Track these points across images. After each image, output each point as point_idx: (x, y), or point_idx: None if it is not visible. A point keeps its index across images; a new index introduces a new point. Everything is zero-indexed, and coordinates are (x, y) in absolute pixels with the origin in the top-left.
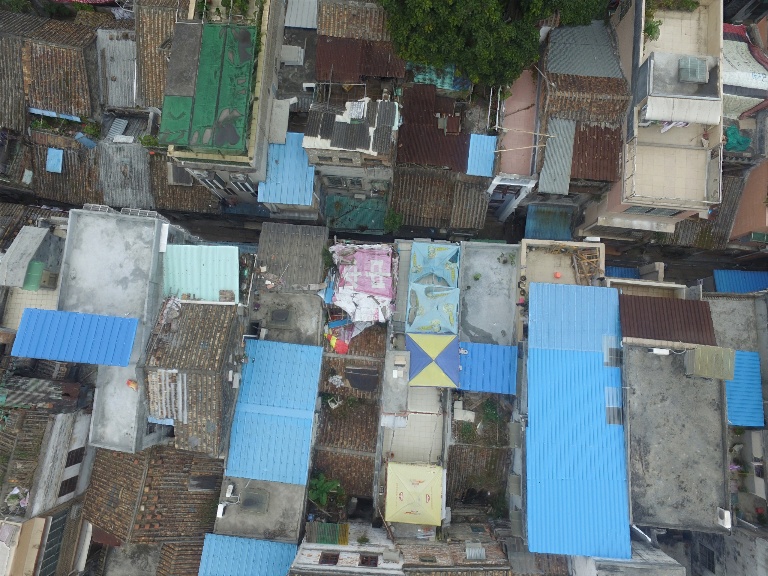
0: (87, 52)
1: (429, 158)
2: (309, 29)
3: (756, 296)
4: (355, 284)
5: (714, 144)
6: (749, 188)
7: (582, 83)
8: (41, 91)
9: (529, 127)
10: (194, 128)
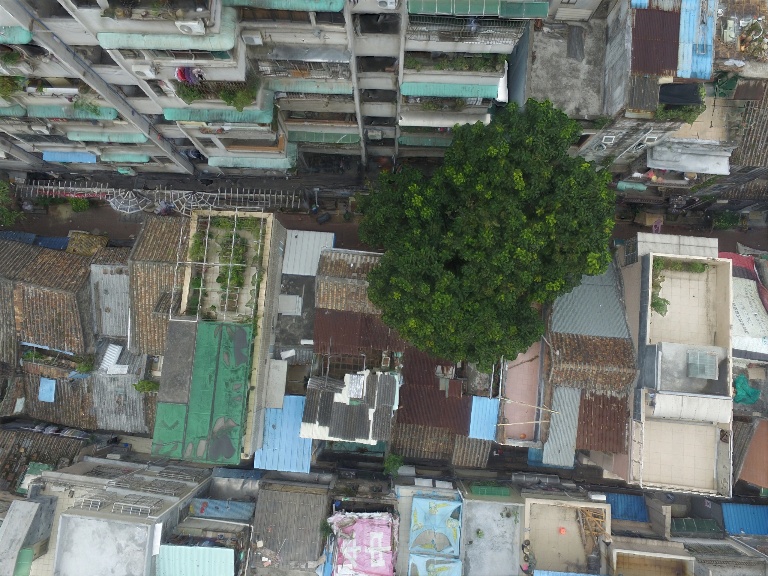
0: (80, 294)
1: (430, 420)
2: (307, 276)
3: (767, 563)
4: (354, 562)
5: (724, 427)
6: (759, 438)
7: (587, 347)
8: (33, 329)
9: (533, 381)
10: (188, 439)
